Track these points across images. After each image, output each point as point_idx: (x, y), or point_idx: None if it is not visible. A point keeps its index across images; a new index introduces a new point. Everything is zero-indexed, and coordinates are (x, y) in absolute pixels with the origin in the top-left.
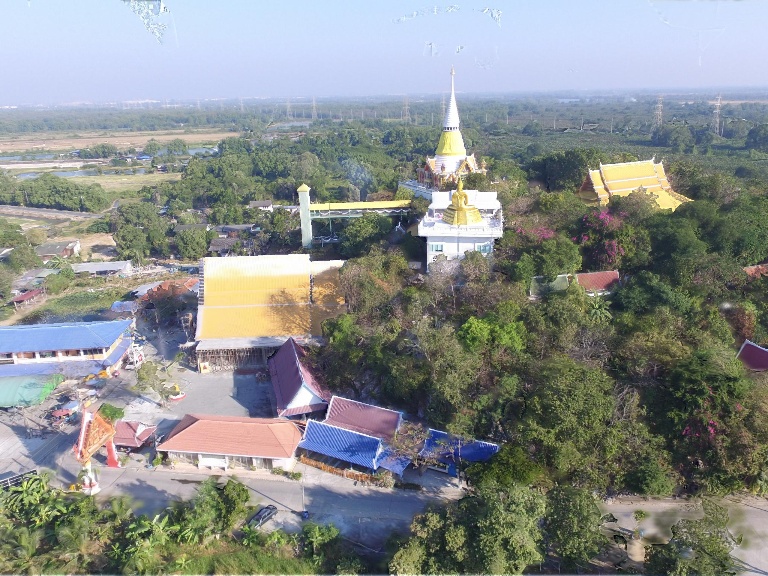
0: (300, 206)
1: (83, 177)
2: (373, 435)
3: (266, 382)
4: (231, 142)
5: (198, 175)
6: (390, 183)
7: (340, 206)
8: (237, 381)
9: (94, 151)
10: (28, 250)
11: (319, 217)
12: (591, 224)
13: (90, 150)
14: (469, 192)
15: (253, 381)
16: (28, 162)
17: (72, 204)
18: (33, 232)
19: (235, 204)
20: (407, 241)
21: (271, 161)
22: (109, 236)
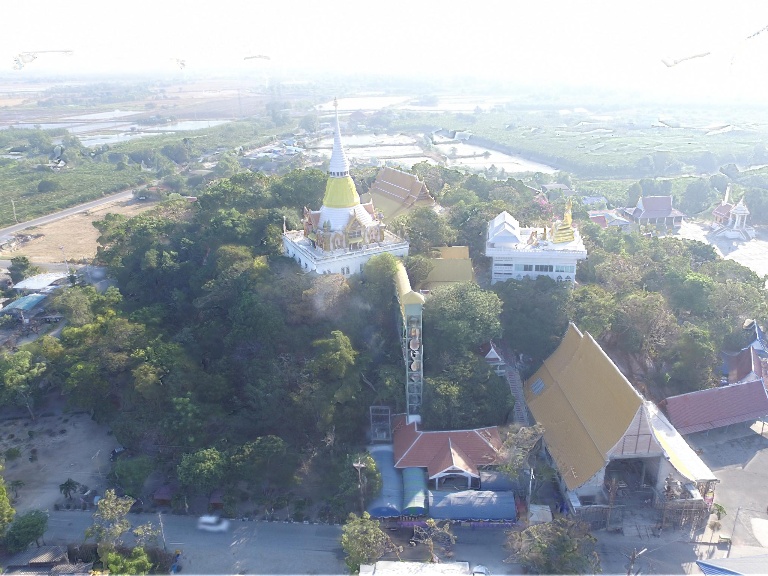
0: None
1: None
2: (766, 369)
3: (698, 447)
4: None
5: None
6: None
7: None
8: (710, 469)
9: None
10: None
11: None
12: (547, 210)
13: None
14: (508, 218)
15: (702, 457)
16: None
17: None
18: None
19: None
20: (547, 278)
21: None
22: None
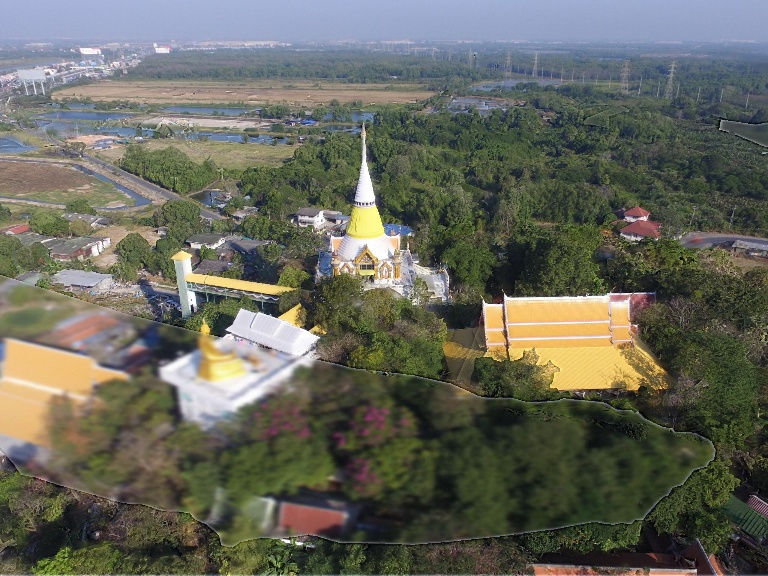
0: (177, 275)
1: (229, 144)
2: None
3: None
4: (386, 114)
5: (305, 159)
6: (445, 207)
7: (215, 282)
8: None
9: (270, 112)
10: (30, 252)
11: (196, 290)
12: None
13: (268, 110)
14: (272, 321)
15: None
16: (217, 118)
17: (168, 184)
18: (75, 224)
19: (280, 210)
20: None
21: (387, 148)
22: (152, 231)
